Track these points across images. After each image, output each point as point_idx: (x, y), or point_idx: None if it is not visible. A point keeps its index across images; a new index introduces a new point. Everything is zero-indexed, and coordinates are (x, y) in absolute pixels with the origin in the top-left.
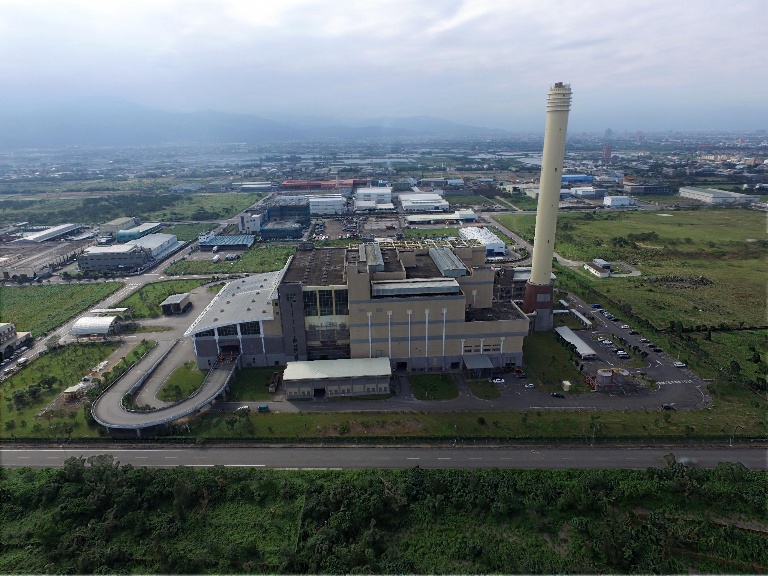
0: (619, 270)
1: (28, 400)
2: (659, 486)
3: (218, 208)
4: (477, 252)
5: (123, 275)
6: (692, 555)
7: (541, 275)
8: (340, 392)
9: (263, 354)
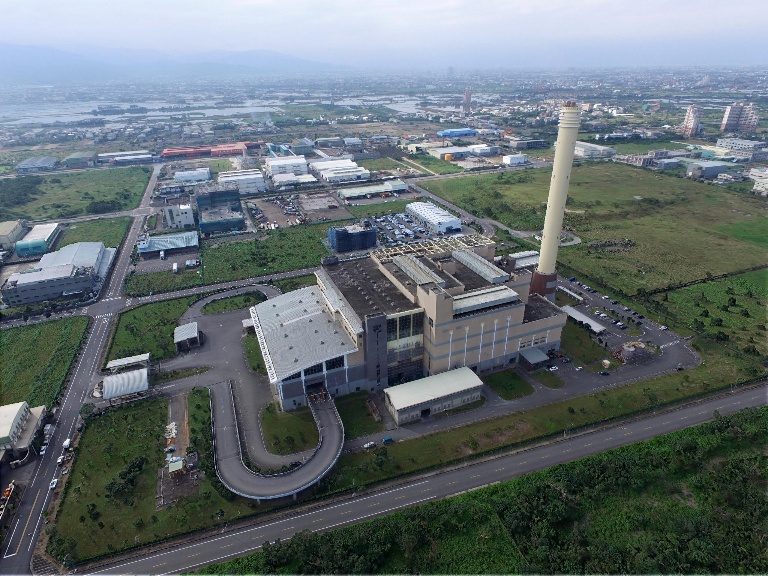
0: (563, 238)
1: (131, 491)
2: (722, 438)
3: (108, 193)
4: (489, 249)
5: None
6: (764, 483)
7: (550, 266)
8: (442, 408)
9: (346, 384)
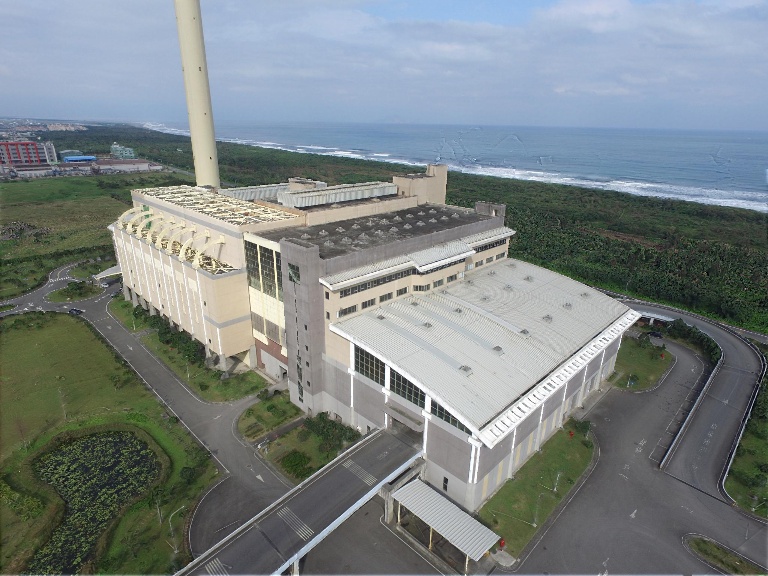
0: None
1: None
2: None
3: None
4: None
5: None
6: None
7: None
8: None
9: None
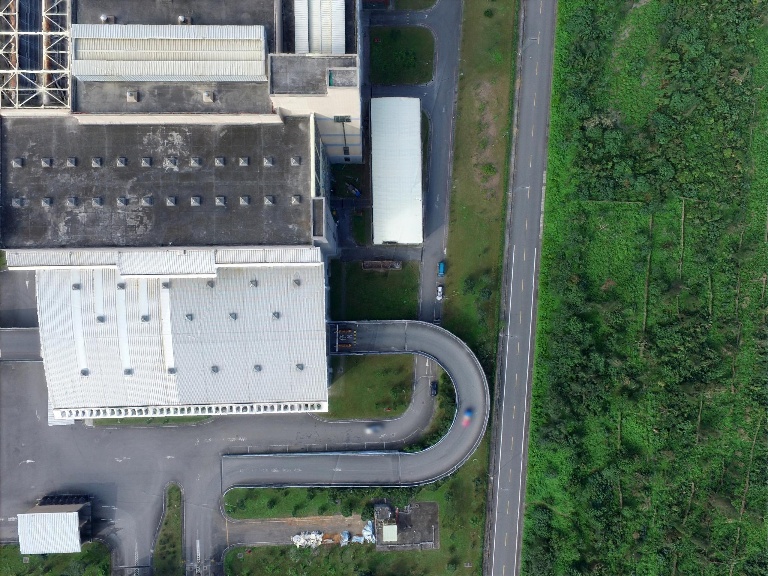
0: None
1: None
2: None
3: None
4: None
5: None
6: None
7: None
8: None
9: None
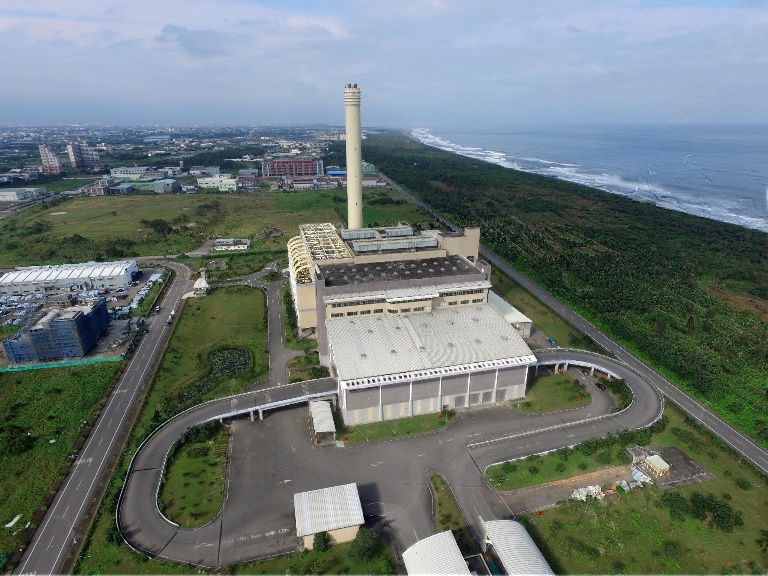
0: None
1: None
2: None
3: None
4: None
5: None
6: None
7: None
8: None
9: None
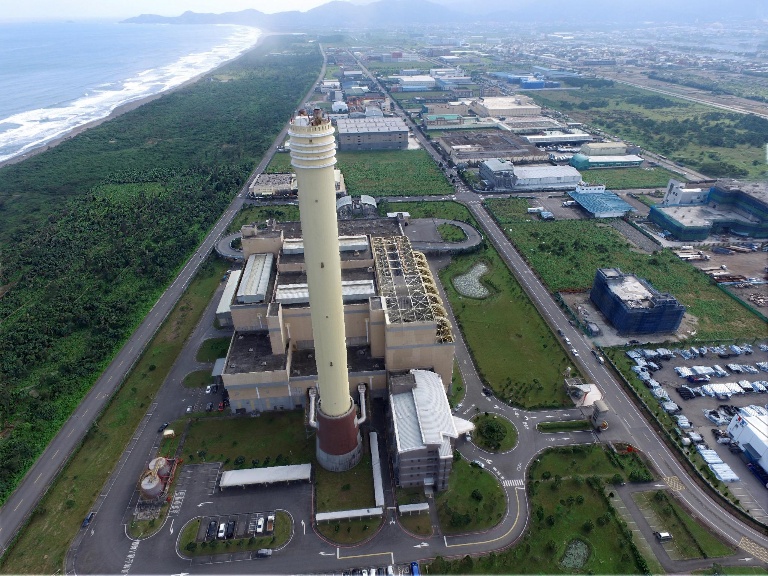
0: None
1: (267, 215)
2: None
3: None
4: None
5: (472, 188)
6: None
7: None
8: None
9: None
